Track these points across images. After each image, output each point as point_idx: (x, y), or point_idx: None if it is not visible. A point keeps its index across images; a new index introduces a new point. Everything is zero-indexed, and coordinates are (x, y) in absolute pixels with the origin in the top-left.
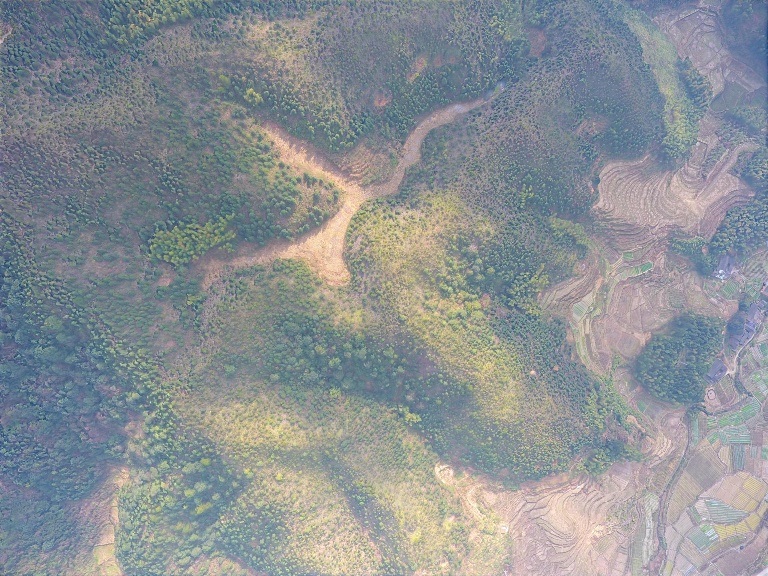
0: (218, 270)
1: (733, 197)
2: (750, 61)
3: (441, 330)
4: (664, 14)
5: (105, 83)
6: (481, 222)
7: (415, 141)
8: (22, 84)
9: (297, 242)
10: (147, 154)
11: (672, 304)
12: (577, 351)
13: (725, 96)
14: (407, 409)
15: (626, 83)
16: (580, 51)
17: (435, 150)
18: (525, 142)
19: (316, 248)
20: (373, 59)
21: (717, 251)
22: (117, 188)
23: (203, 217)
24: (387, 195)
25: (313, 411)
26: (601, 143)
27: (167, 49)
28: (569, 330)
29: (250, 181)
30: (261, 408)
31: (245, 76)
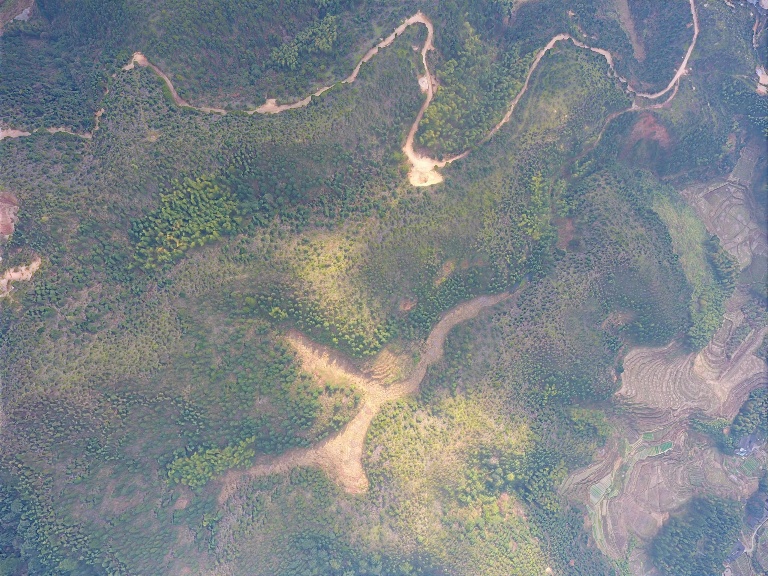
0: (235, 481)
1: (757, 379)
2: None
3: (458, 545)
4: (693, 187)
5: (131, 317)
6: (503, 432)
7: (438, 335)
8: (48, 327)
9: (316, 447)
10: (170, 394)
11: (691, 482)
12: (593, 535)
13: (752, 269)
14: None
15: (655, 283)
16: (609, 254)
17: (459, 353)
18: (550, 349)
19: (334, 453)
20: (400, 271)
21: (739, 434)
22: (138, 427)
23: (223, 439)
24: (408, 396)
25: None
26: (626, 333)
27: (194, 277)
28: (586, 516)
29: (272, 402)
30: None
31: (271, 296)
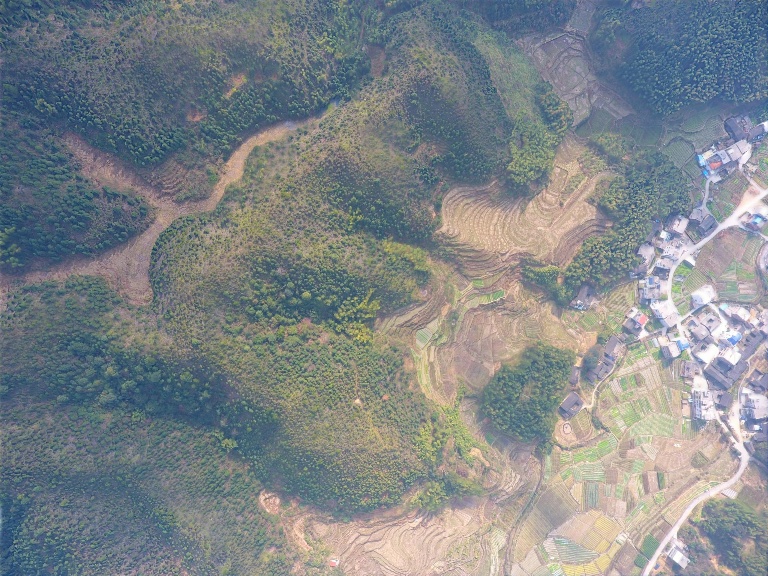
0: (7, 285)
1: (590, 226)
2: (617, 87)
3: (242, 355)
4: (529, 36)
5: None
6: (293, 245)
7: (240, 158)
8: None
9: (100, 258)
10: None
11: (527, 334)
12: (418, 379)
13: (592, 122)
14: (221, 435)
15: (461, 106)
16: (410, 72)
17: (252, 168)
18: (345, 163)
19: (120, 265)
20: (180, 73)
21: (571, 281)
22: None
23: None
24: (202, 213)
25: (108, 435)
26: (443, 166)
27: None
28: (408, 357)
29: (34, 194)
30: (44, 430)
31: (34, 86)
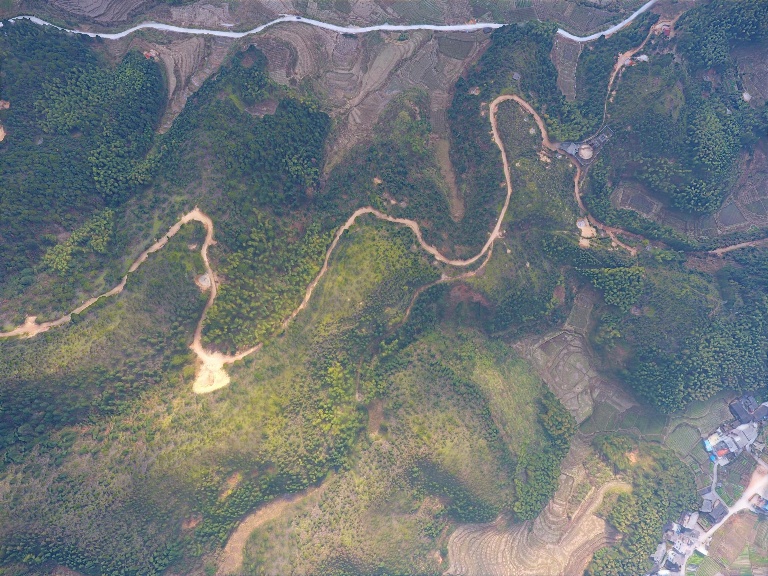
0: None
1: (600, 539)
2: (619, 383)
3: None
4: (527, 339)
5: None
6: None
7: (238, 540)
8: None
9: None
10: None
11: None
12: None
13: (595, 417)
14: None
15: (464, 472)
16: (410, 449)
17: (252, 567)
18: (348, 558)
19: None
20: (173, 495)
21: None
22: None
23: None
24: None
25: None
26: (448, 513)
27: None
28: None
29: None
30: None
31: (20, 545)
